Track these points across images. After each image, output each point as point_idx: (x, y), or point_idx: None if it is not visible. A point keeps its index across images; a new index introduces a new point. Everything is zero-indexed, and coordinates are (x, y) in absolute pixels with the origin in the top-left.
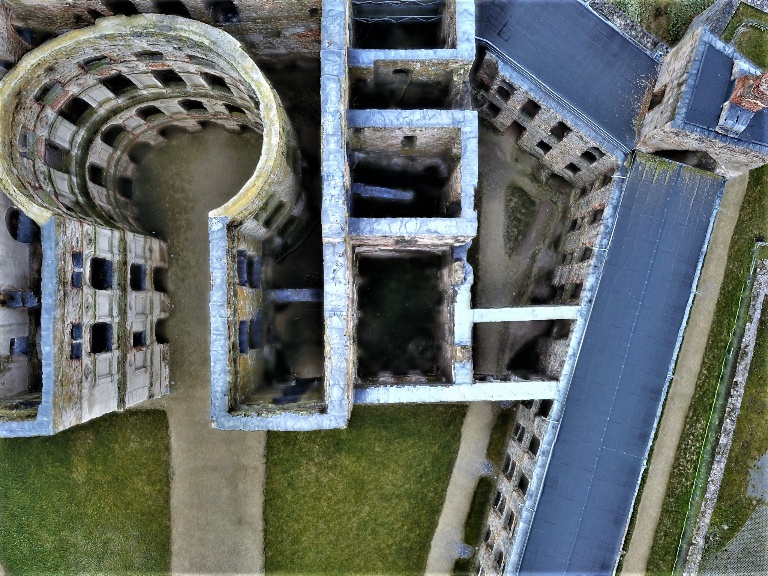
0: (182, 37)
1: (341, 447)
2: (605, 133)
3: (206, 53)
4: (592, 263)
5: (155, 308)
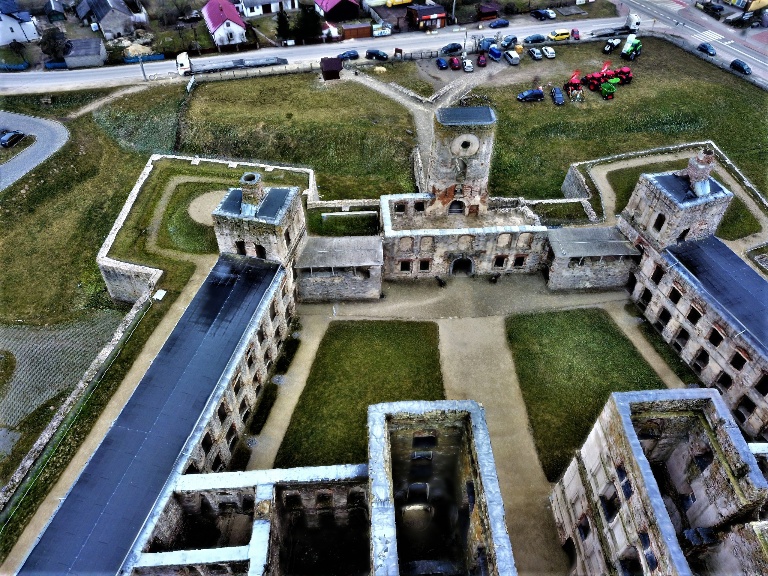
0: None
1: None
2: None
3: None
4: None
5: (582, 572)
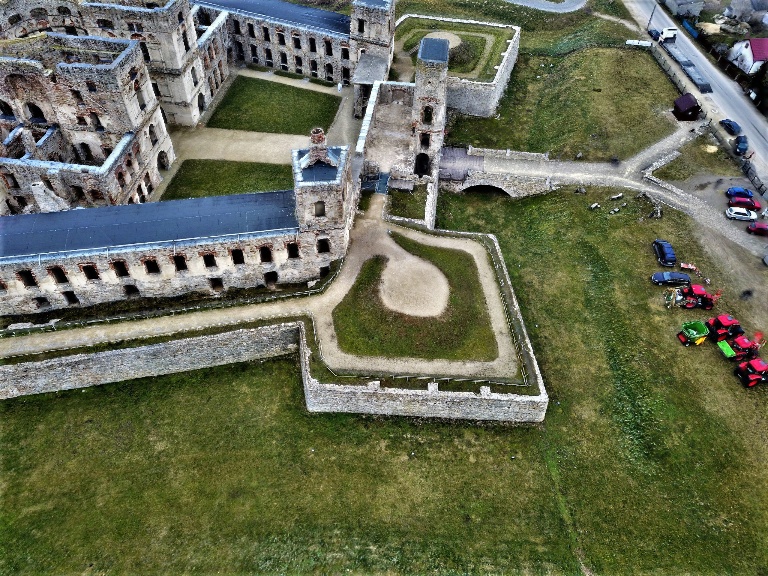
0: (3, 2)
1: (238, 107)
2: None
3: (14, 6)
4: None
5: None
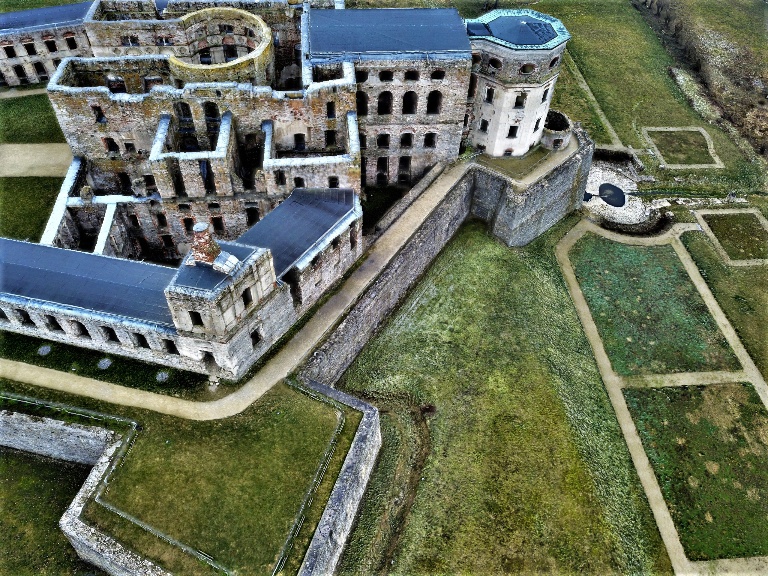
0: None
1: None
2: None
3: None
4: (132, 260)
5: None
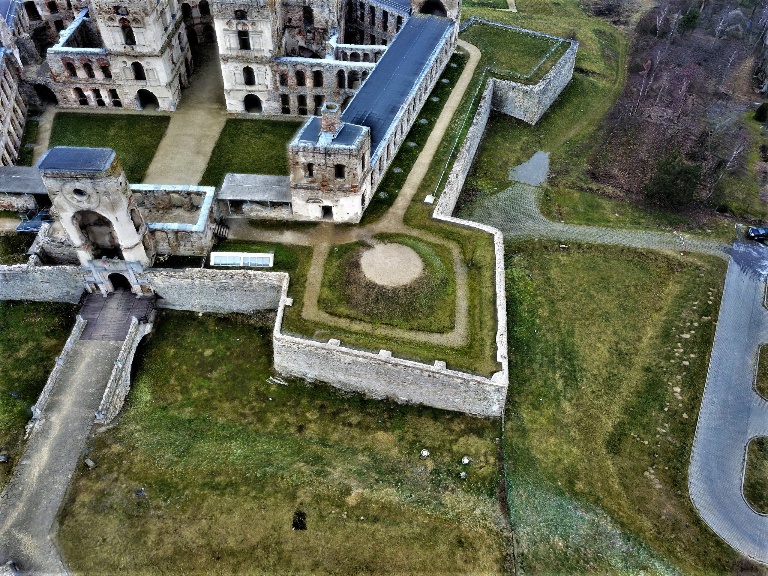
0: None
1: (265, 132)
2: (399, 5)
3: None
4: None
5: (182, 68)
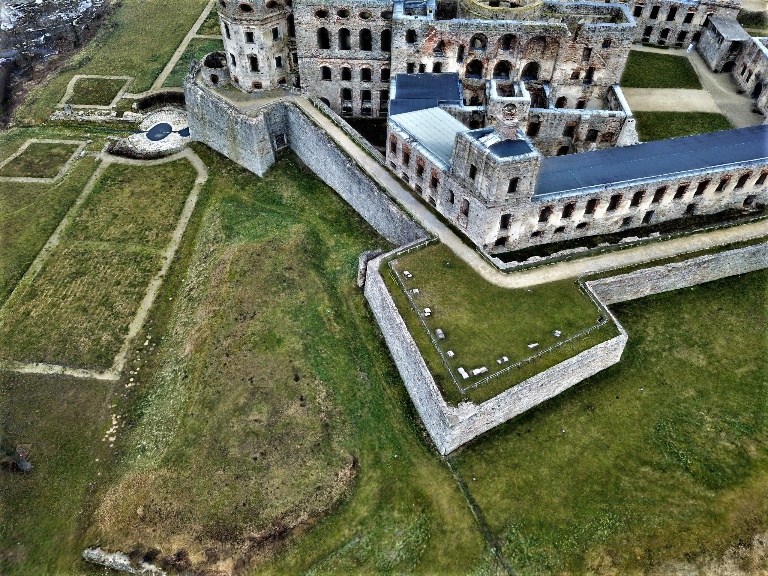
0: None
1: None
2: None
3: None
4: None
5: None
